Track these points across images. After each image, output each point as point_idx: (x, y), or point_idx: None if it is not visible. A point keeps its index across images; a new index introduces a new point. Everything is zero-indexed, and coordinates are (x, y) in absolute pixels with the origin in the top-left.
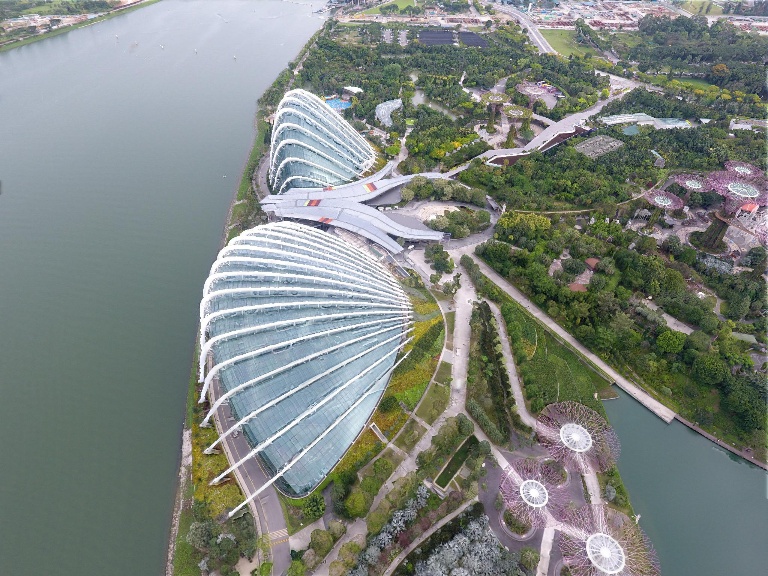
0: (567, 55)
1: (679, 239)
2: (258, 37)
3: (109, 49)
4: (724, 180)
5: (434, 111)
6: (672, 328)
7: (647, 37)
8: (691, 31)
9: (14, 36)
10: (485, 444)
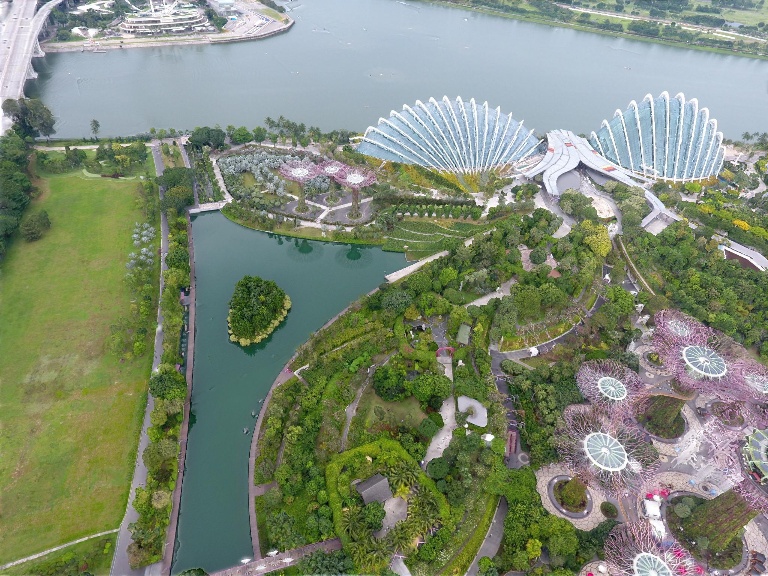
0: None
1: (629, 357)
2: None
3: None
4: (729, 356)
5: None
6: (475, 301)
7: None
8: None
9: (762, 52)
10: (370, 188)
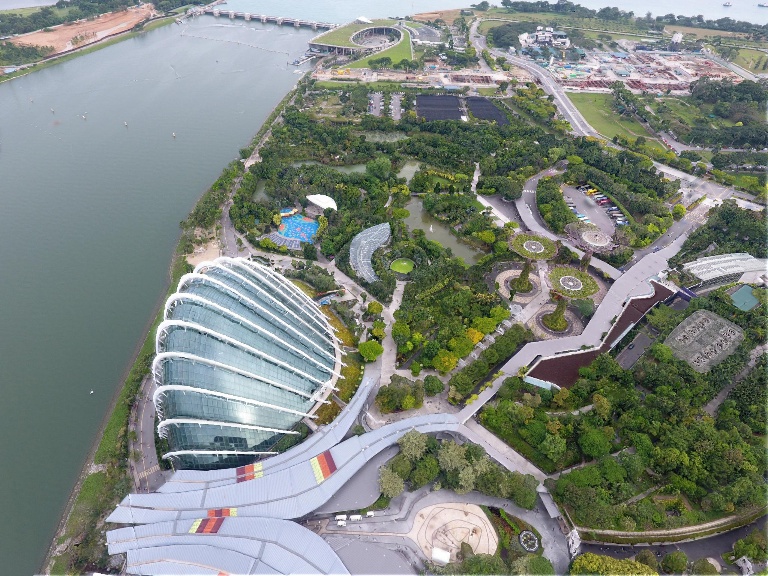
0: (609, 135)
1: None
2: (213, 101)
3: (14, 119)
4: None
5: (437, 249)
6: None
7: (706, 107)
8: (760, 99)
9: None
10: None
